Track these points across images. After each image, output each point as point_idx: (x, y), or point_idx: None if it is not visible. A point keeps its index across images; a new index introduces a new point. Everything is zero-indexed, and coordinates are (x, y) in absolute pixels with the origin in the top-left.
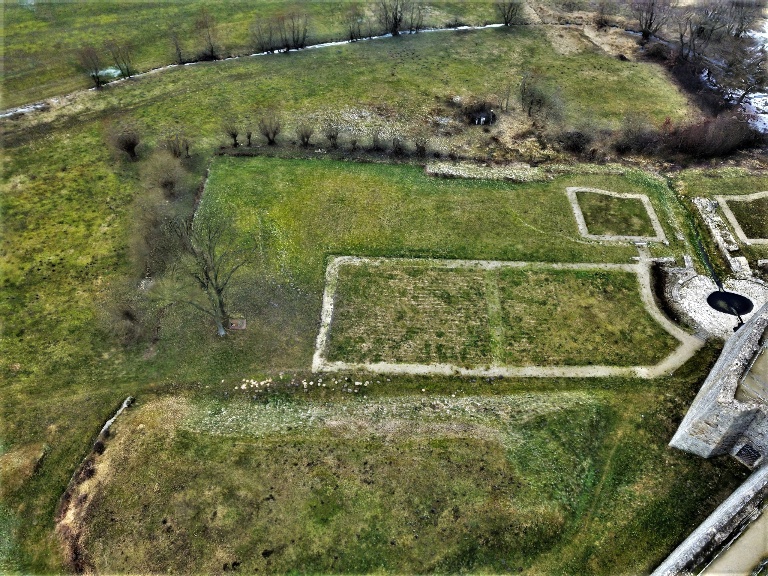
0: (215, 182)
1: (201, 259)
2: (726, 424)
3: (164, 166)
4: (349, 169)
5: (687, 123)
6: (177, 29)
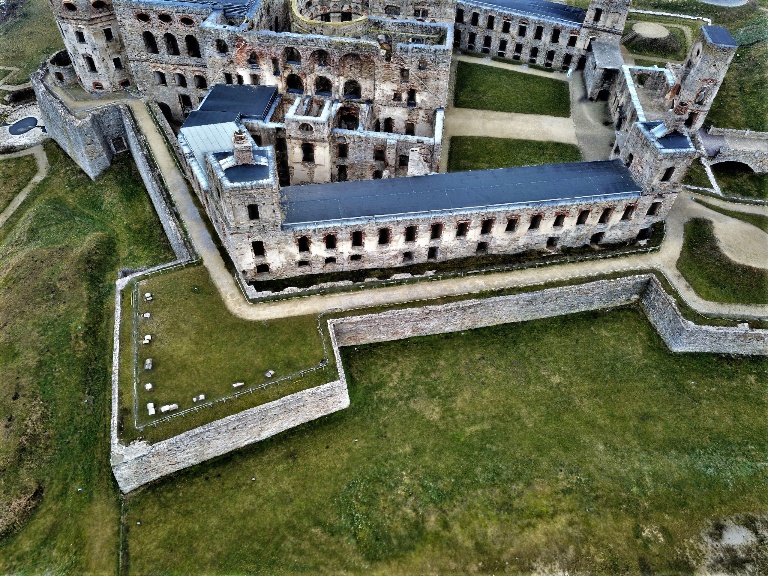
0: None
1: None
2: (93, 135)
3: None
4: None
5: None
6: None
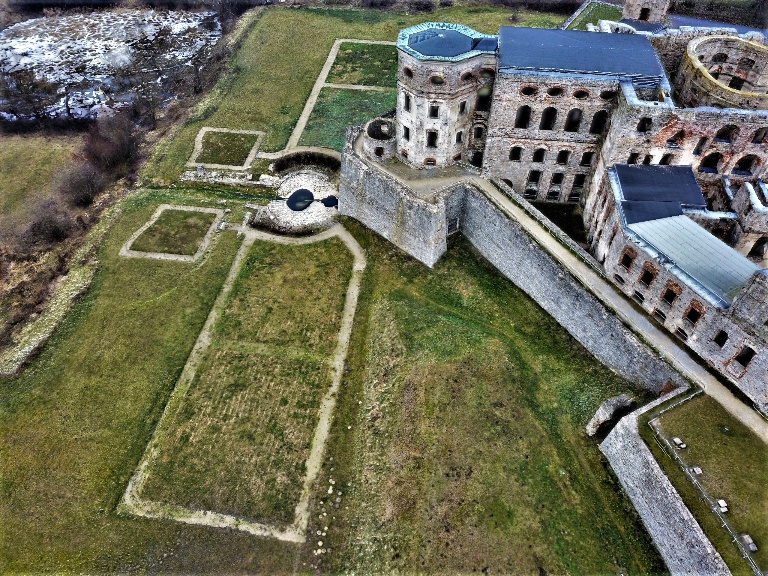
0: None
1: None
2: (444, 220)
3: None
4: None
5: (76, 150)
6: None
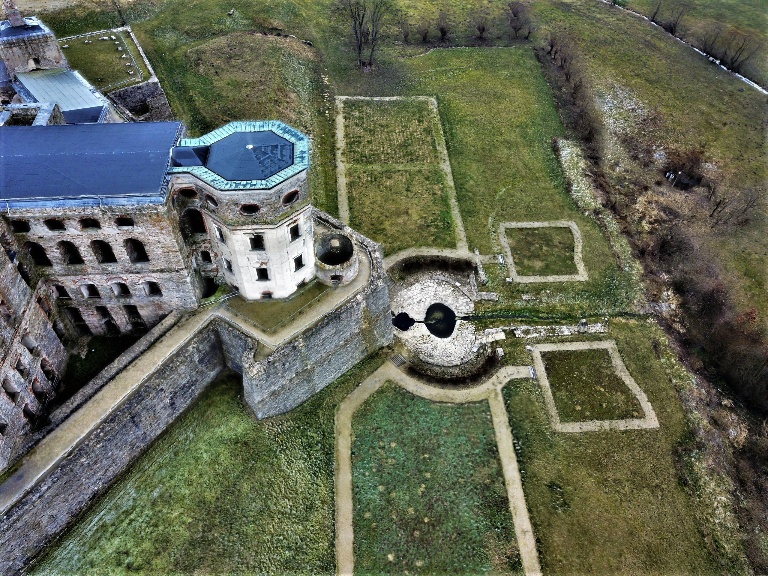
0: (500, 50)
1: (364, 5)
2: None
3: (511, 32)
4: (541, 100)
5: None
6: (701, 8)
